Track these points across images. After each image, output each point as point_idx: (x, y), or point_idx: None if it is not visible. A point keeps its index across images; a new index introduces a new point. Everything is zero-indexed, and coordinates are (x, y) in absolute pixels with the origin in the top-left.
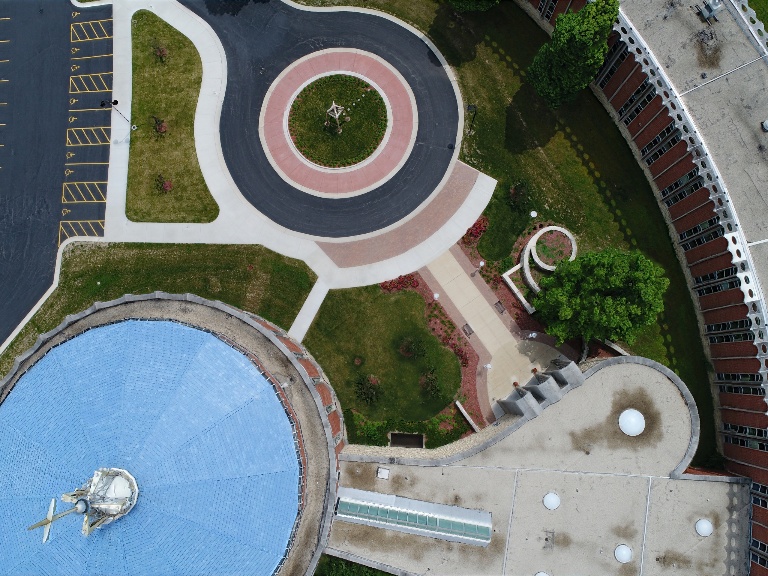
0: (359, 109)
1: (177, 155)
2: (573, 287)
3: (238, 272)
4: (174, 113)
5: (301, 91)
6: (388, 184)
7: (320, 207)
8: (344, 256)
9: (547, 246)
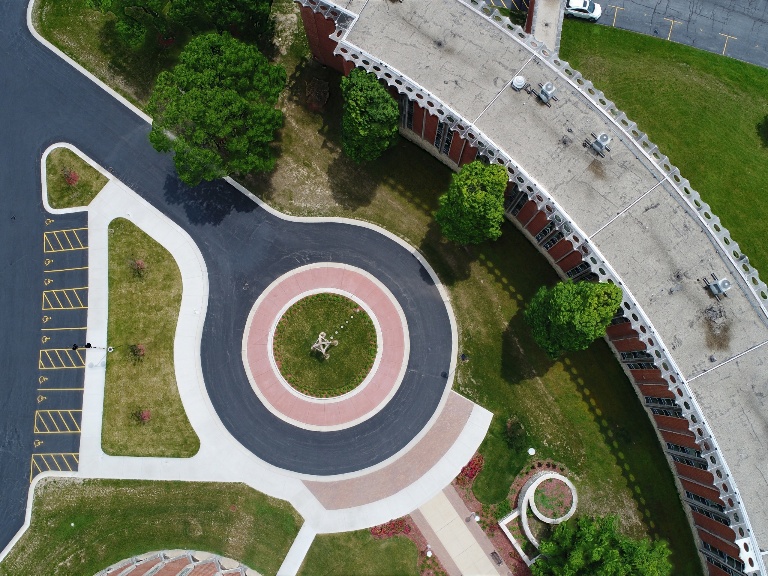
0: (347, 332)
1: (156, 381)
2: (574, 575)
3: (220, 513)
4: (152, 334)
5: (286, 311)
6: (378, 416)
7: (306, 441)
8: (332, 497)
9: (546, 496)
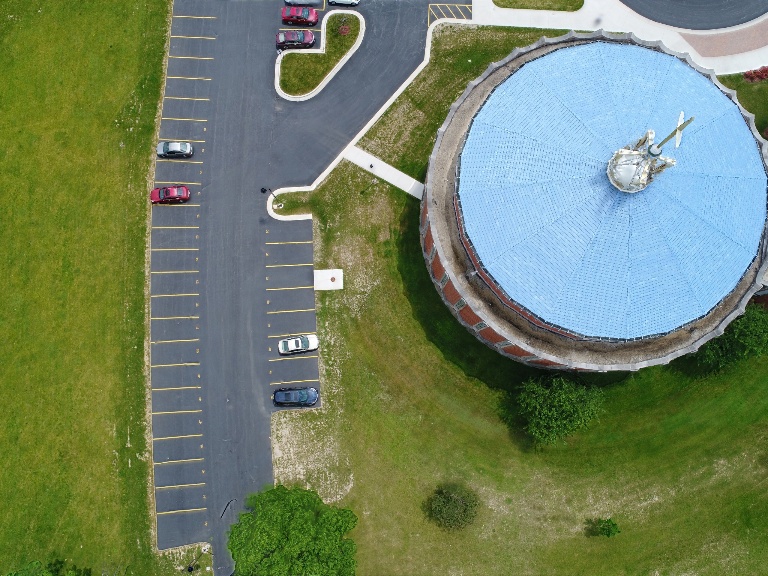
0: None
1: None
2: None
3: None
4: None
5: None
6: None
7: (681, 2)
8: (707, 47)
9: None
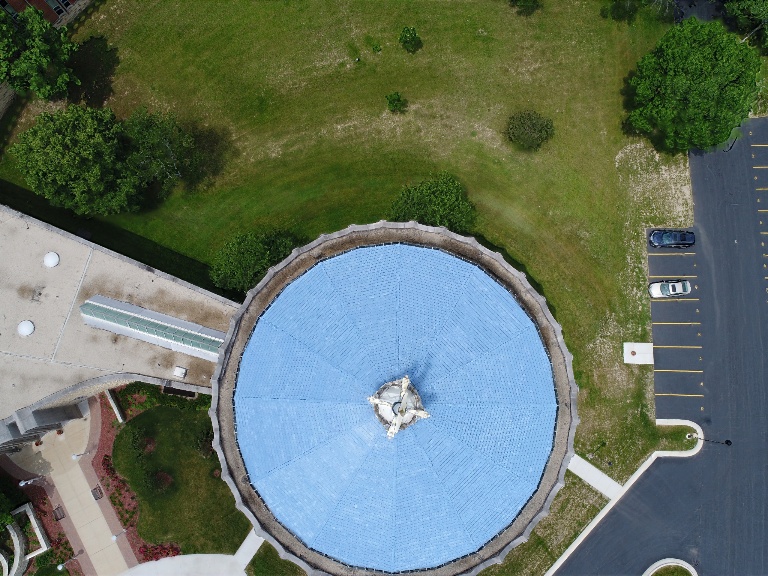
0: None
1: None
2: None
3: None
4: None
5: None
6: None
7: None
8: None
9: None
